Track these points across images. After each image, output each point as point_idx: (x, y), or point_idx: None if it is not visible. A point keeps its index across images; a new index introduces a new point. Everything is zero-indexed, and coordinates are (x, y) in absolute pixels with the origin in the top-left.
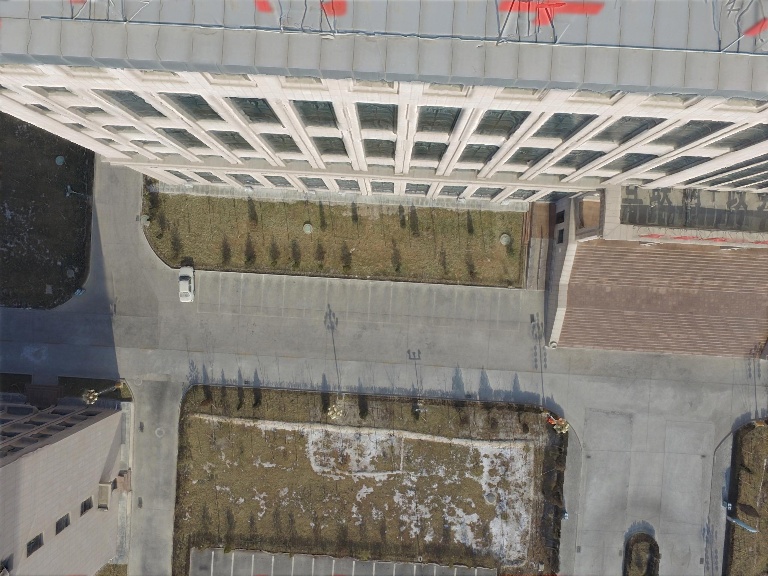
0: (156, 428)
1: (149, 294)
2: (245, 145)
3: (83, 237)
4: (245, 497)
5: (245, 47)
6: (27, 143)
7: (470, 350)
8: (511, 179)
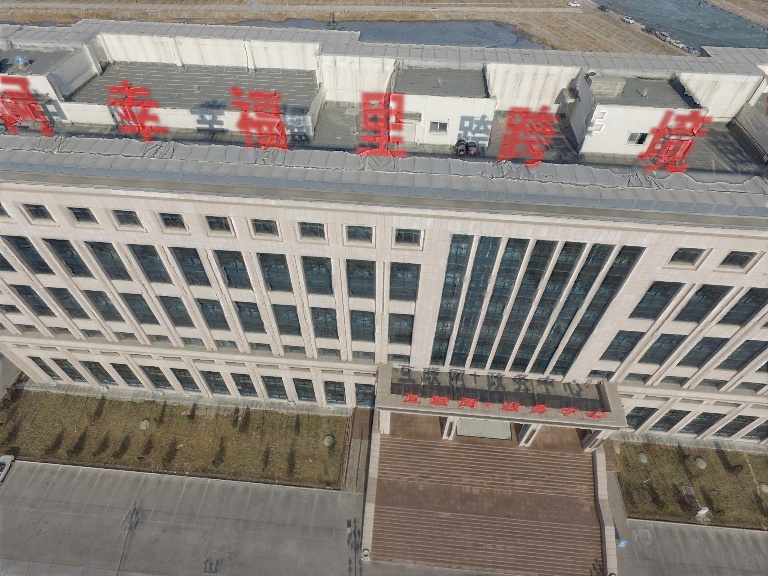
0: None
1: None
2: (82, 313)
3: None
4: None
5: (8, 155)
6: None
7: (276, 562)
8: (301, 357)
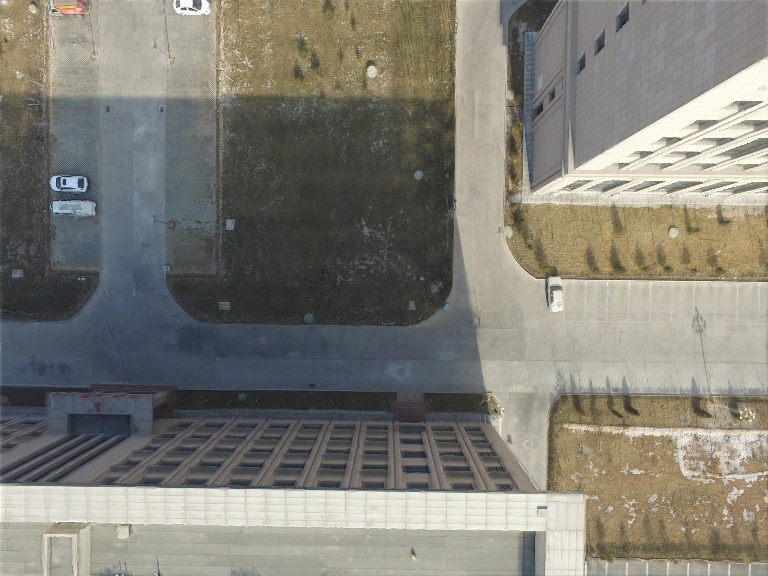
0: (524, 440)
1: (514, 306)
2: None
3: (445, 251)
4: (614, 505)
5: None
6: (383, 159)
7: None
8: None
